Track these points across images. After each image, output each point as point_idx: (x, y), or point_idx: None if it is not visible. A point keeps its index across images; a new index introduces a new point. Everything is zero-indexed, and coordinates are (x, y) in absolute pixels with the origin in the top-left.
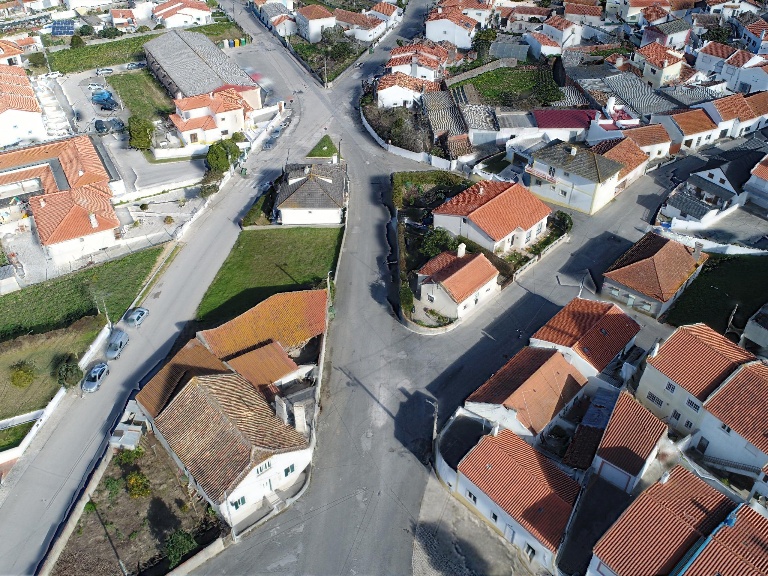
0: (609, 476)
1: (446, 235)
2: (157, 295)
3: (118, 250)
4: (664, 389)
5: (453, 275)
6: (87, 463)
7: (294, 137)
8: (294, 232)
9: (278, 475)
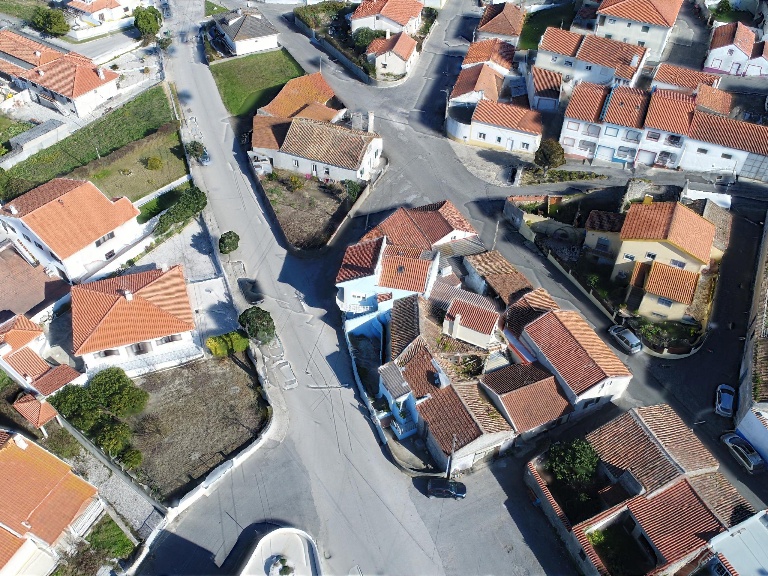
0: (544, 106)
1: (369, 30)
2: (189, 111)
3: (122, 97)
4: (551, 62)
5: (396, 45)
6: (246, 189)
7: (180, 6)
8: (250, 58)
9: (373, 156)
